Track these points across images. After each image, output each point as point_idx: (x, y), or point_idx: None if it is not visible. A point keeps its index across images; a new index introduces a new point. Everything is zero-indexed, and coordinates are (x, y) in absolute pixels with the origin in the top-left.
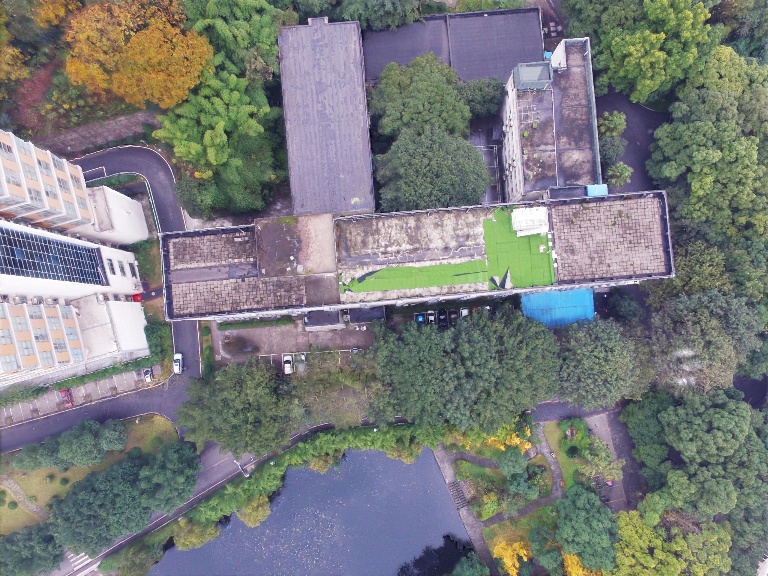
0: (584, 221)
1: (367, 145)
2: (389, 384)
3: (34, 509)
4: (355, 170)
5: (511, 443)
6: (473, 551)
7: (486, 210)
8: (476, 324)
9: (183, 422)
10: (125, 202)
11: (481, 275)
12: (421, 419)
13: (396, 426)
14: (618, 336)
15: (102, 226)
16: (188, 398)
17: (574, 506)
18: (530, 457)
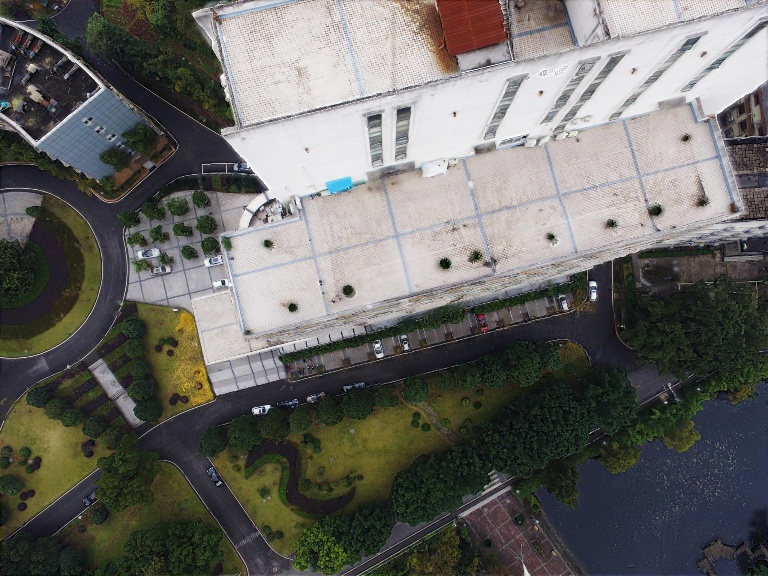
0: None
1: None
2: None
3: (446, 432)
4: None
5: None
6: None
7: None
8: None
9: (642, 340)
10: None
11: None
12: None
13: None
14: None
15: None
16: (599, 326)
17: None
18: None
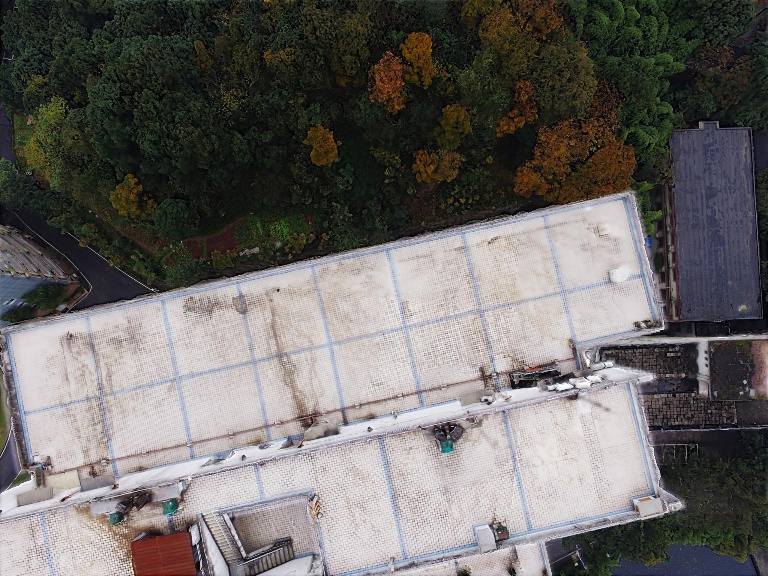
0: None
1: (756, 253)
2: None
3: None
4: (743, 277)
5: None
6: None
7: None
8: None
9: None
10: None
11: None
12: None
13: None
14: None
15: None
16: None
17: None
18: None
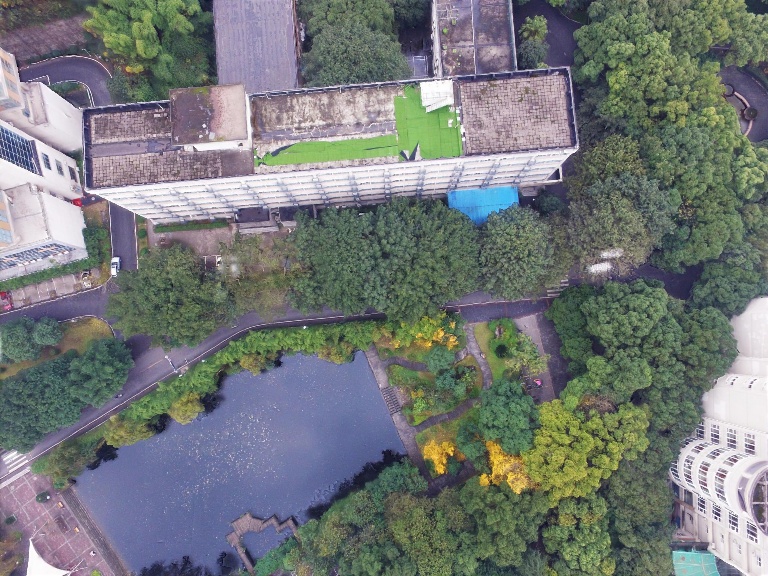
0: (492, 97)
1: (292, 42)
2: (309, 267)
3: None
4: (280, 65)
5: (438, 339)
6: (406, 456)
7: (397, 87)
8: (396, 210)
9: (112, 311)
10: (65, 106)
11: (391, 149)
12: (343, 305)
13: (326, 325)
14: (532, 217)
15: (38, 120)
16: None
17: (496, 394)
18: (460, 358)
